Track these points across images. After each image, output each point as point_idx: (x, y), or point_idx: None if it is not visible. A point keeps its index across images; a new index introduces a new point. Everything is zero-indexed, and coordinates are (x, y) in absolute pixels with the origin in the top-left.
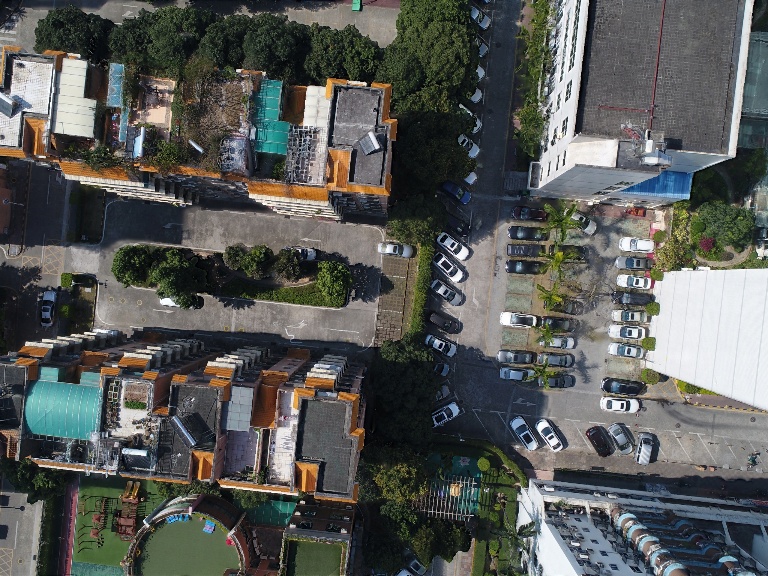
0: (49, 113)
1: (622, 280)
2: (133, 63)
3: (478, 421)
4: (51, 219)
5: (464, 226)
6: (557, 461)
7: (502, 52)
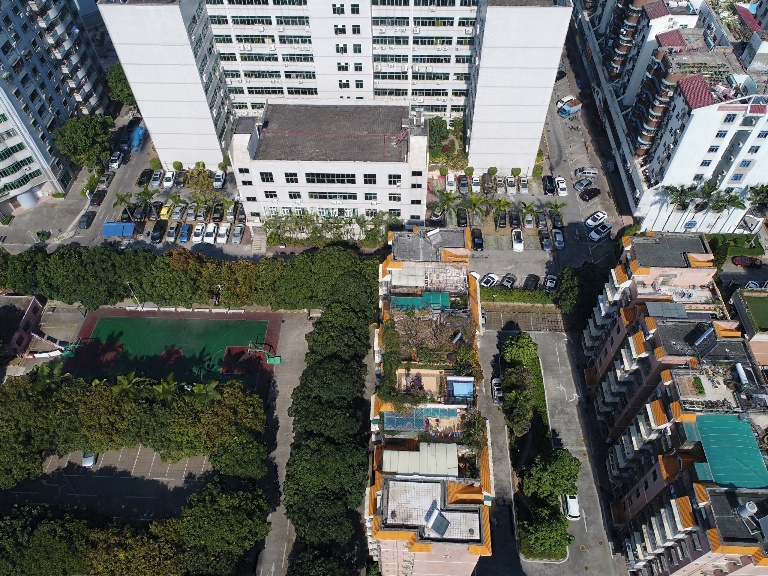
0: None
1: (476, 189)
2: None
3: (601, 261)
4: None
5: None
6: (613, 215)
7: None
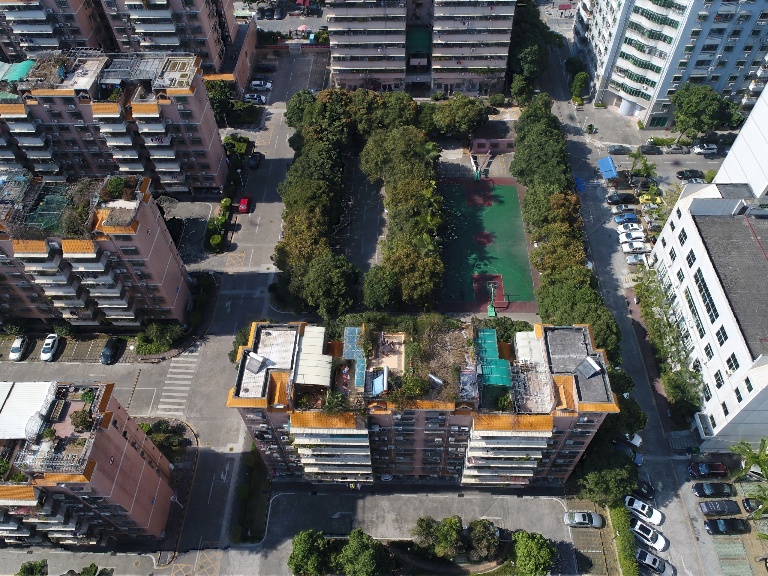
0: (292, 367)
1: None
2: (372, 321)
3: None
4: (211, 519)
5: (647, 487)
6: None
7: (624, 337)
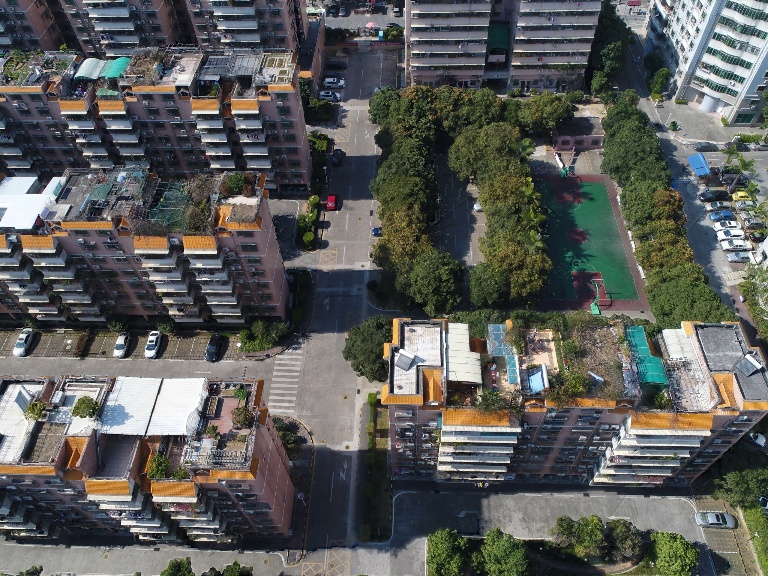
0: None
1: None
2: (520, 317)
3: None
4: (335, 518)
5: None
6: None
7: None
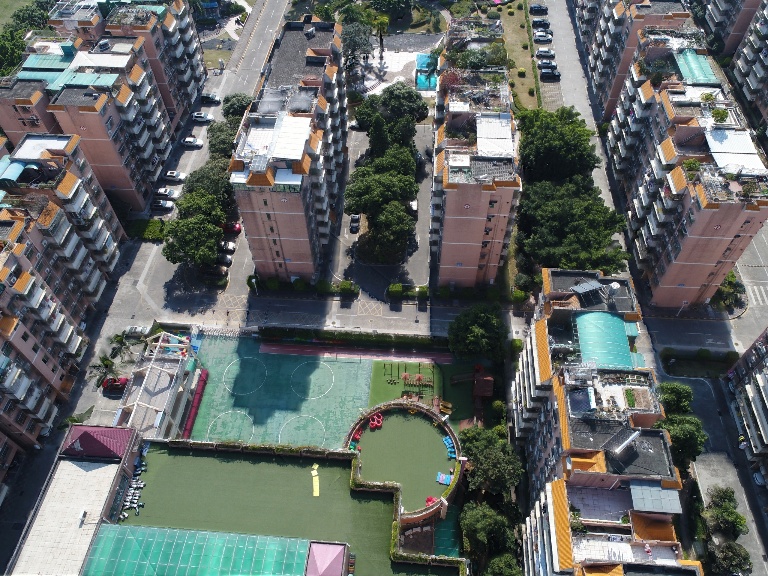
0: None
1: None
2: None
3: None
4: (673, 336)
5: None
6: None
7: None
